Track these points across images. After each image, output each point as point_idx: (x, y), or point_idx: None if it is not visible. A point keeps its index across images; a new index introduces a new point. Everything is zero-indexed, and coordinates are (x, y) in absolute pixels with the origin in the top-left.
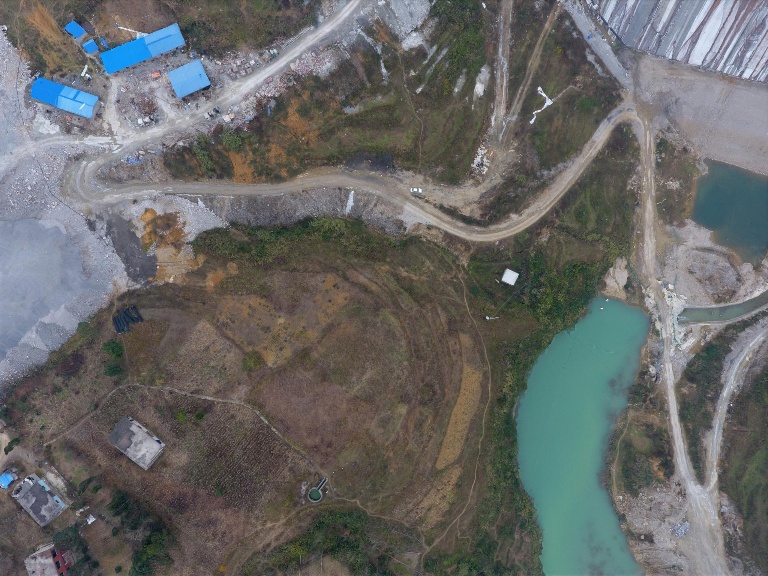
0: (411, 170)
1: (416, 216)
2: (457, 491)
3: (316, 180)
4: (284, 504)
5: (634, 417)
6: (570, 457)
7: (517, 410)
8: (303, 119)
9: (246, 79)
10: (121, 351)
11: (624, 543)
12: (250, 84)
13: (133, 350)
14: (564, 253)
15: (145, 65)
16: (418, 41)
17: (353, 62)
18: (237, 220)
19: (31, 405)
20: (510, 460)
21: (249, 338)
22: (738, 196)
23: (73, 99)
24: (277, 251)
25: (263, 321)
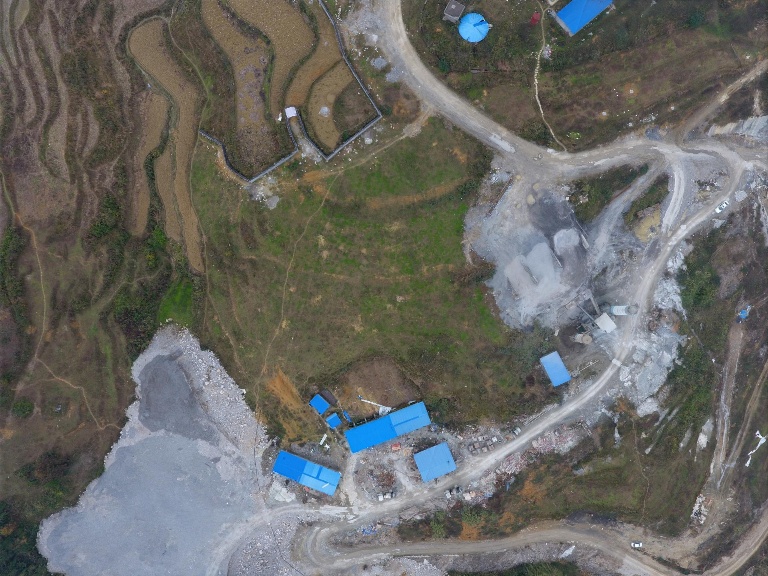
0: (632, 523)
1: (634, 568)
2: None
3: (539, 535)
4: None
5: None
6: None
7: None
8: (535, 485)
9: (487, 454)
10: None
11: None
12: (490, 460)
13: None
14: None
15: None
16: (653, 407)
17: (592, 436)
18: (455, 569)
19: None
20: None
21: None
22: None
23: (317, 478)
24: None
25: None
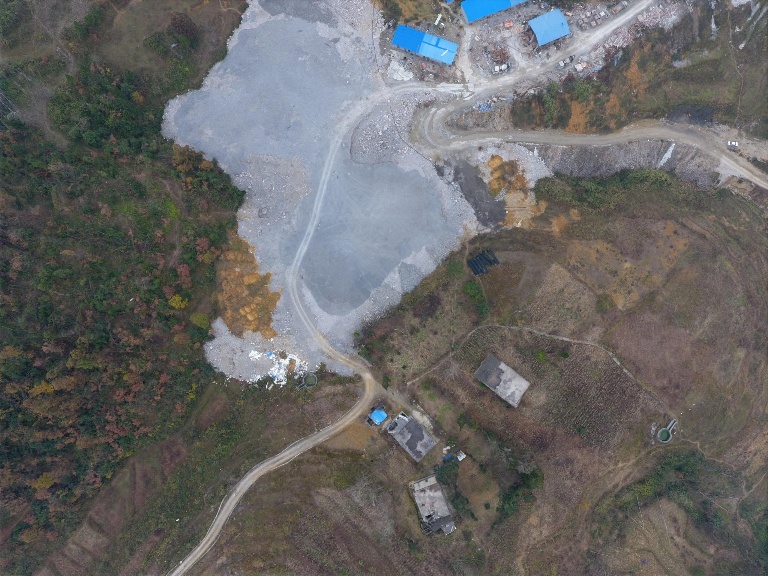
0: (727, 124)
1: (731, 169)
2: None
3: (640, 132)
4: (636, 444)
5: None
6: None
7: None
8: (639, 71)
9: (595, 30)
10: None
11: None
12: (599, 35)
13: (493, 291)
14: None
15: (498, 15)
16: None
17: (693, 16)
18: (561, 171)
19: (390, 345)
20: None
21: (600, 281)
22: None
23: (436, 46)
24: (616, 198)
25: (610, 265)
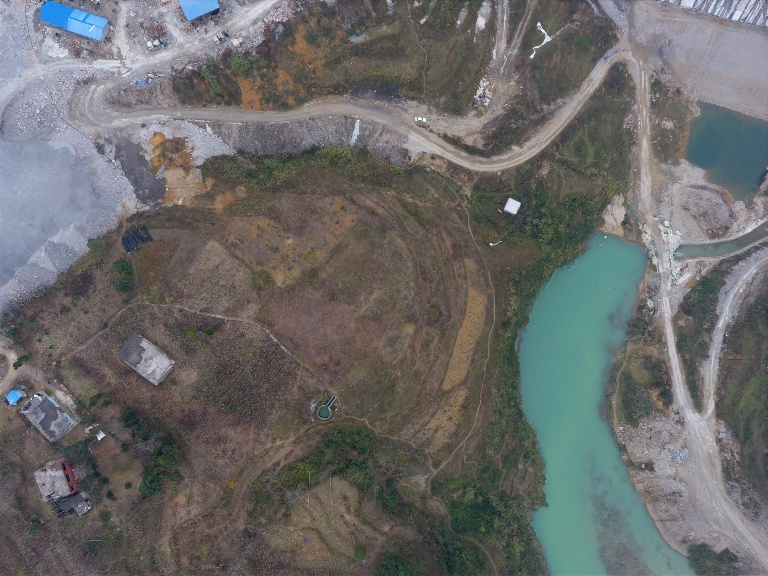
0: (415, 100)
1: (420, 145)
2: (463, 412)
3: (322, 108)
4: (294, 421)
5: (633, 350)
6: (571, 391)
7: (519, 345)
8: (310, 46)
9: (254, 4)
10: (131, 270)
11: (625, 474)
12: (258, 9)
13: (143, 269)
14: (564, 186)
15: None
16: None
17: None
18: (244, 148)
19: (40, 325)
20: (513, 390)
21: (258, 258)
22: (729, 137)
23: (83, 21)
24: (285, 175)
25: (272, 242)
